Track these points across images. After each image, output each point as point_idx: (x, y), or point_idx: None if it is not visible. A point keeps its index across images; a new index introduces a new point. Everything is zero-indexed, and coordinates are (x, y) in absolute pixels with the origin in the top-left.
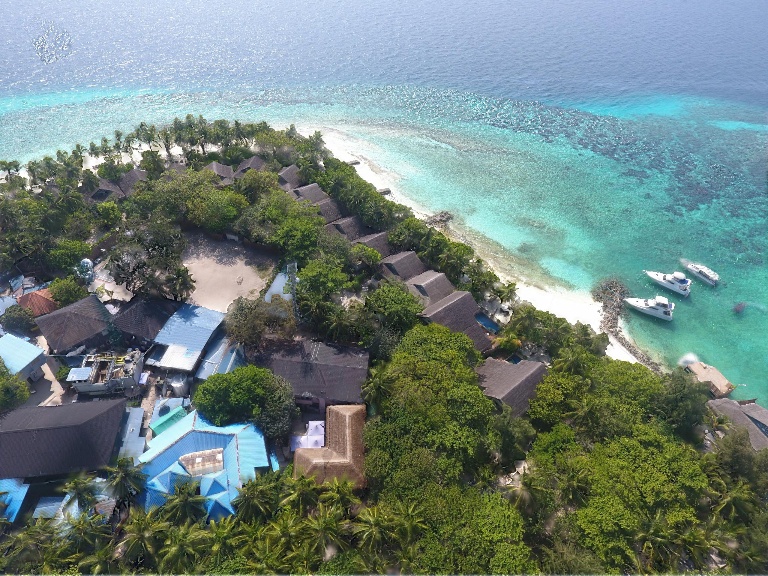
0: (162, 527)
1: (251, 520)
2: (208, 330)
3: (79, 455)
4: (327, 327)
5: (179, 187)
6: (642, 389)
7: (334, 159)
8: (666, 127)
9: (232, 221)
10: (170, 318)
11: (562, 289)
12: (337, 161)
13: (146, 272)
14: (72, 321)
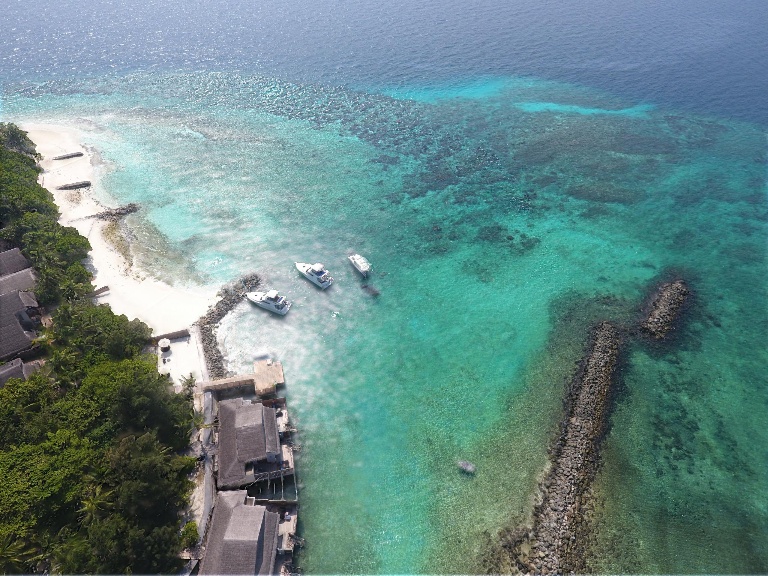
0: None
1: None
2: None
3: None
4: None
5: None
6: (106, 391)
7: (8, 152)
8: (462, 110)
9: None
10: None
11: (192, 284)
12: (13, 154)
13: None
14: None
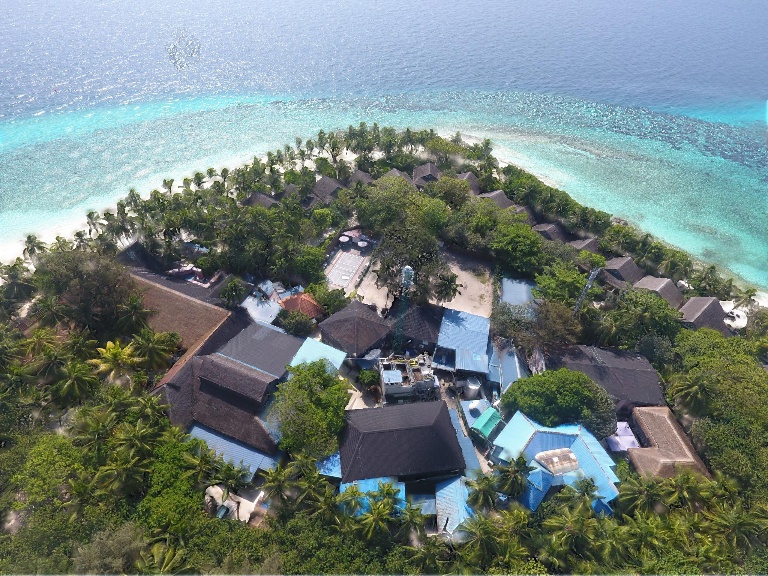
0: (594, 522)
1: (655, 516)
2: (484, 334)
3: (439, 454)
4: (601, 331)
5: (396, 194)
6: None
7: (514, 166)
8: None
9: (441, 227)
10: (442, 322)
11: (764, 294)
12: None
13: (419, 278)
14: (361, 325)
